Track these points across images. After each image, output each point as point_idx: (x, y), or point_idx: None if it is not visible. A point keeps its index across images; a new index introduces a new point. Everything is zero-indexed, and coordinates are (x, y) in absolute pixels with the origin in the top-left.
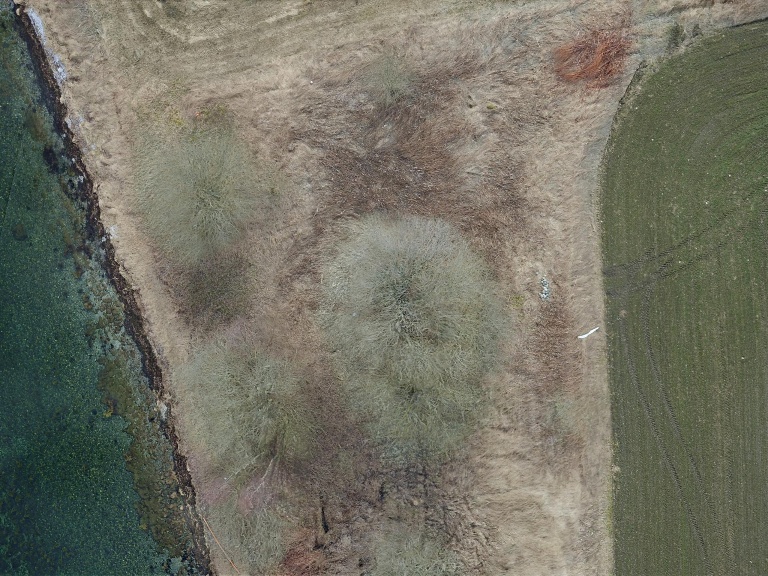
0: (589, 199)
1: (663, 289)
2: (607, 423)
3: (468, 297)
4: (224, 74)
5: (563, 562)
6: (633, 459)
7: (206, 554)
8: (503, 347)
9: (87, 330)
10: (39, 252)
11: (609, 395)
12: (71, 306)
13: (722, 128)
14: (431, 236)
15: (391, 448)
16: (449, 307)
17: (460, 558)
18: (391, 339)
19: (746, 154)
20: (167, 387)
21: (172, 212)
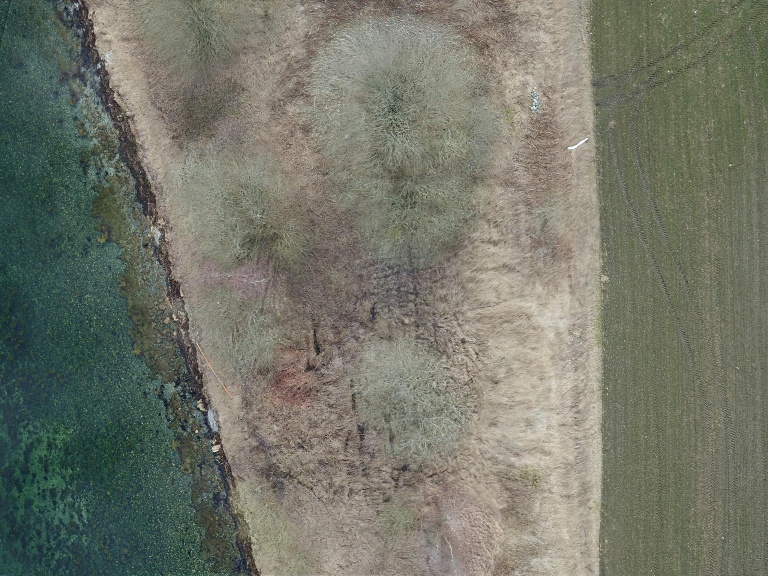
0: (579, 11)
1: (652, 99)
2: (596, 233)
3: (459, 115)
4: None
5: (552, 372)
6: (621, 268)
7: (199, 379)
8: (493, 161)
9: (82, 157)
10: (35, 80)
11: (598, 206)
12: (66, 134)
13: None
14: (423, 57)
15: (382, 268)
16: None
17: (450, 375)
18: (383, 159)
19: None
20: (161, 213)
21: (166, 37)
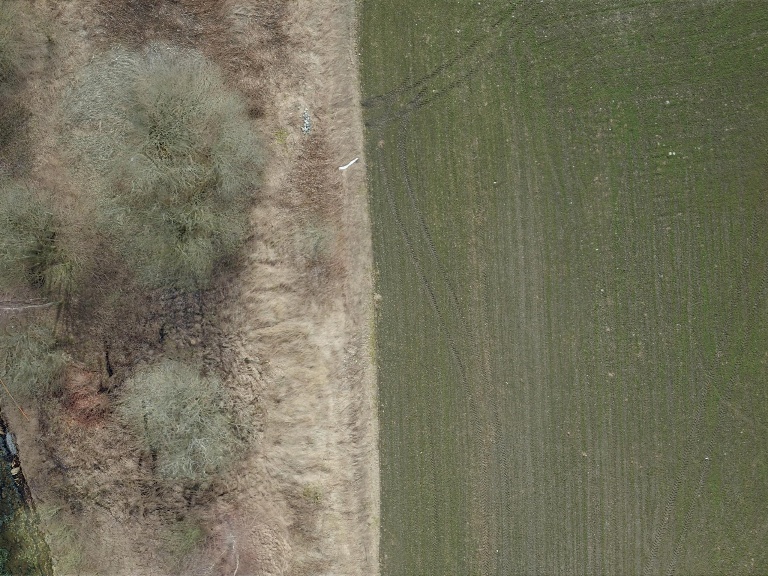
0: (347, 32)
1: (418, 118)
2: (368, 252)
3: (238, 137)
4: None
5: (329, 390)
6: (393, 286)
7: None
8: (269, 182)
9: None
10: None
11: (370, 225)
12: None
13: None
14: (204, 79)
15: (170, 290)
16: (221, 147)
17: (236, 395)
18: None
19: None
20: None
21: None
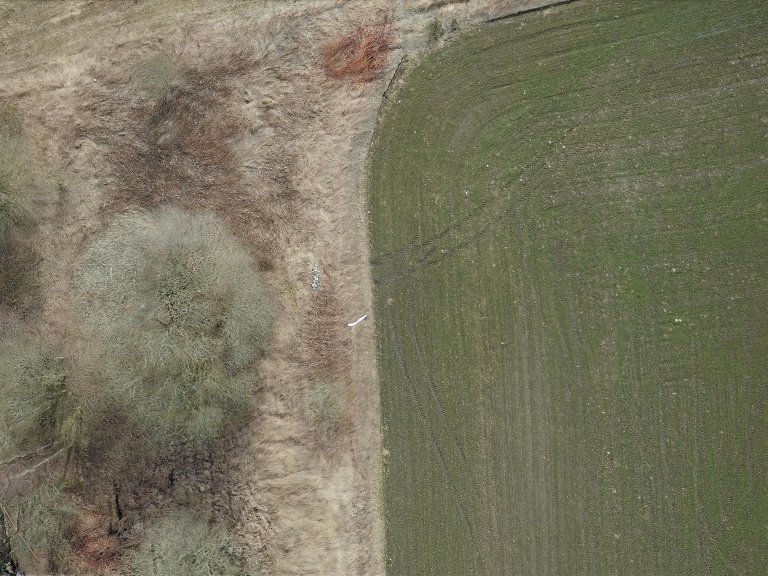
0: (356, 190)
1: (427, 277)
2: (376, 408)
3: (248, 288)
4: (13, 73)
5: (337, 544)
6: (401, 443)
7: (7, 542)
8: (278, 336)
9: None
10: None
11: (378, 381)
12: None
13: (480, 120)
14: (214, 229)
15: (179, 436)
16: (230, 298)
17: (245, 542)
18: None
19: (502, 145)
20: None
21: None
